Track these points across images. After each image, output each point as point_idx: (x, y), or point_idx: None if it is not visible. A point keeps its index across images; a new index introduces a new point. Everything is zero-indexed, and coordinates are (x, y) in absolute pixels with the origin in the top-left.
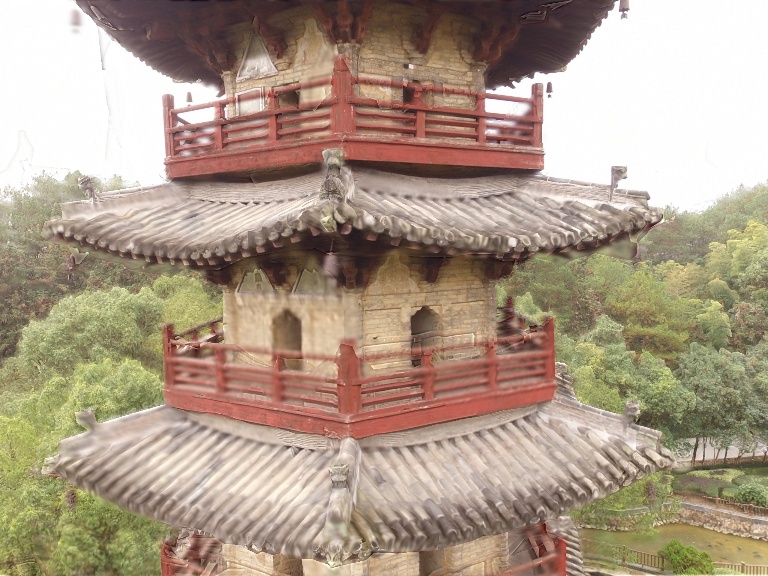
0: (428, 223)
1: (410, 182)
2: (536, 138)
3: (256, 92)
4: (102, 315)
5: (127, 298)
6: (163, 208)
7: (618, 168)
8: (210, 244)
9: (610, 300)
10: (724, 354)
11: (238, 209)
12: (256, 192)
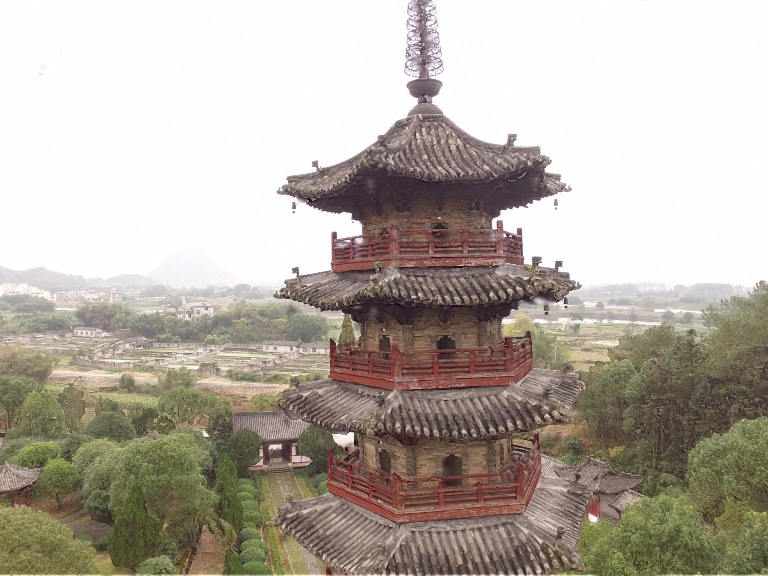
0: (313, 533)
1: None
2: None
3: None
4: (743, 447)
5: None
6: None
7: None
8: None
9: None
10: None
11: None
12: None
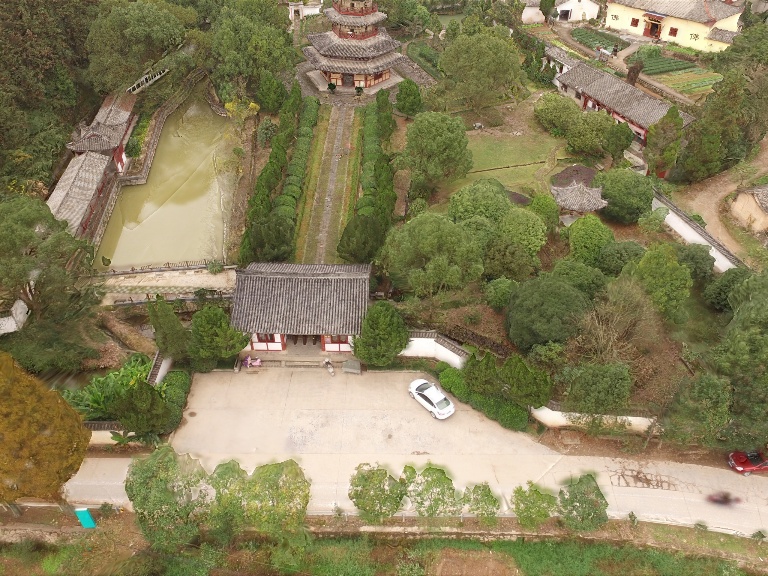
0: None
1: None
2: None
3: None
4: None
5: (155, 5)
6: None
7: None
8: None
9: None
10: None
11: None
12: None
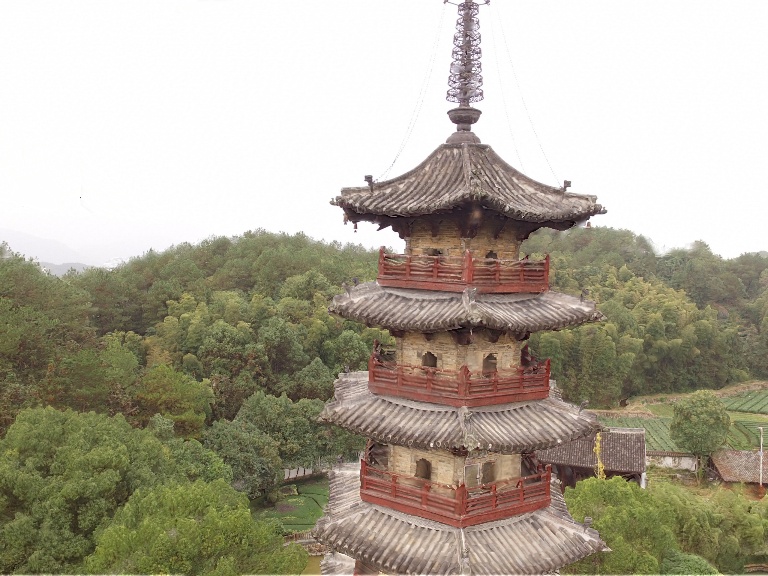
0: None
1: None
2: None
3: (477, 466)
4: None
5: None
6: None
7: None
8: None
9: (138, 393)
10: (227, 424)
11: (495, 534)
12: (498, 523)
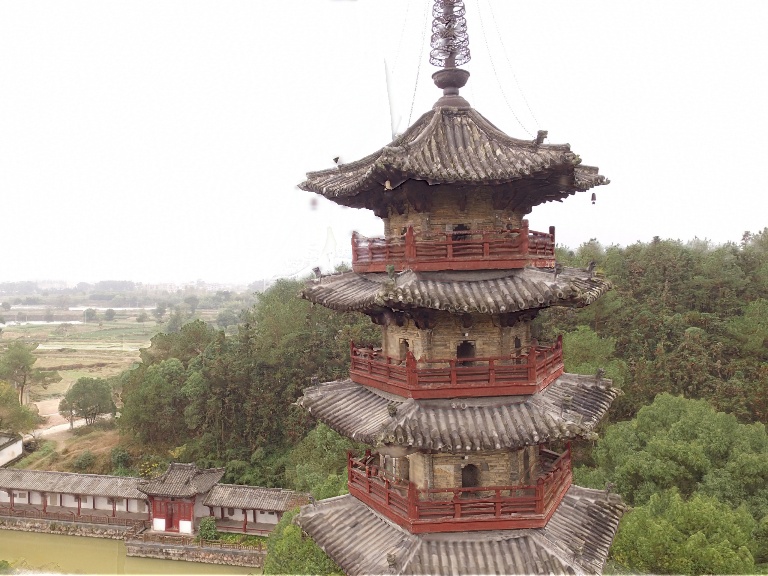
0: None
1: (457, 534)
2: (539, 509)
3: None
4: None
5: None
6: (345, 511)
7: (577, 548)
8: (349, 570)
9: None
10: None
11: (377, 524)
12: None
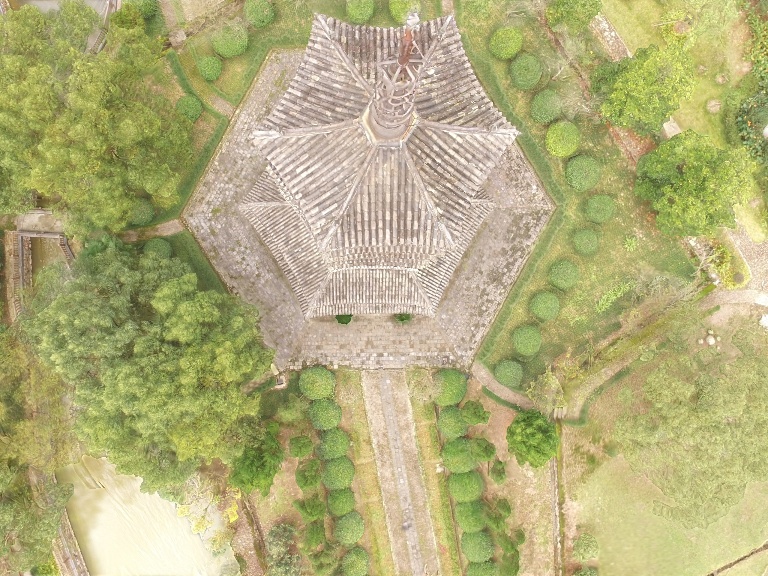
0: None
1: None
2: None
3: None
4: None
5: None
6: None
7: None
8: None
9: None
10: None
11: None
12: None
